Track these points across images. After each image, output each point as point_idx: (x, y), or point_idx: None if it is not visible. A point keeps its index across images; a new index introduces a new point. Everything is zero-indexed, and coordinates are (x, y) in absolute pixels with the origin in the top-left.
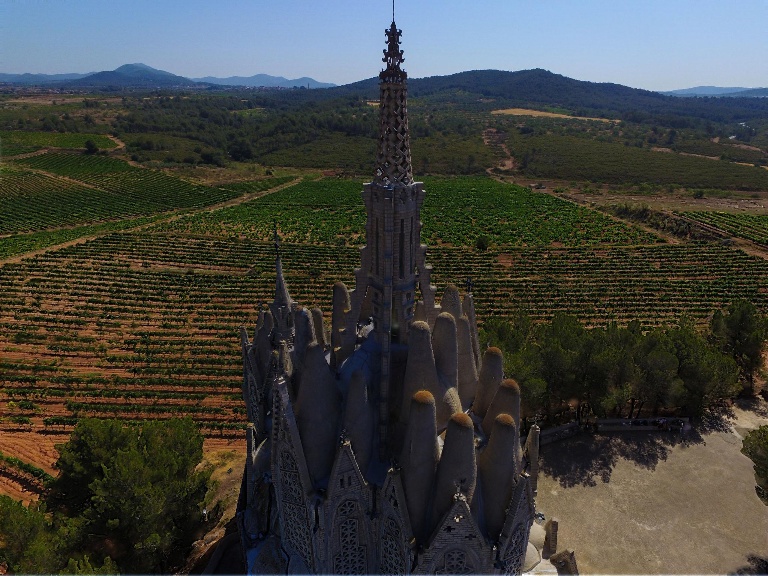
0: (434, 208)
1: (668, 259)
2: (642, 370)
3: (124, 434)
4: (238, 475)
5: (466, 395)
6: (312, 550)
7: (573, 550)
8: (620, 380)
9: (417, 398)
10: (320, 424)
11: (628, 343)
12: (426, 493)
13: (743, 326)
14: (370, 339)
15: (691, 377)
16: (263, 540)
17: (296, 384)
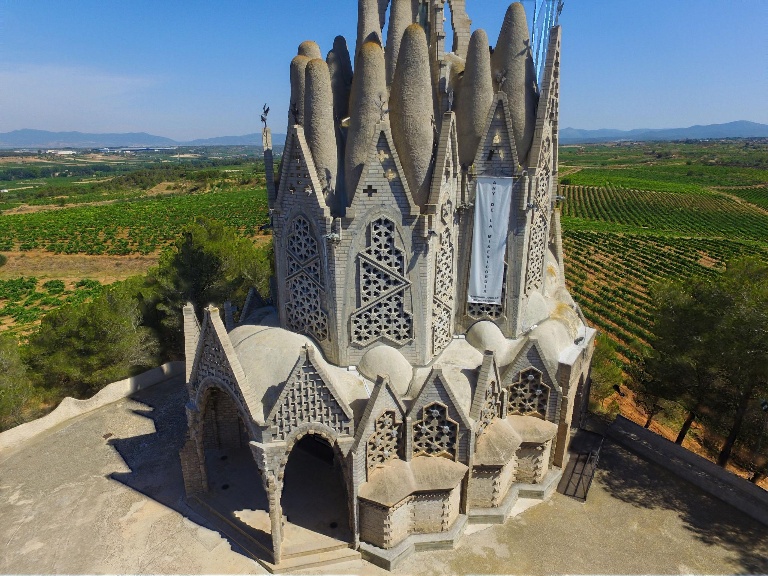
0: None
1: None
2: None
3: None
4: None
5: (464, 155)
6: None
7: (383, 376)
8: None
9: None
10: None
11: None
12: None
13: None
14: None
15: None
16: None
17: None
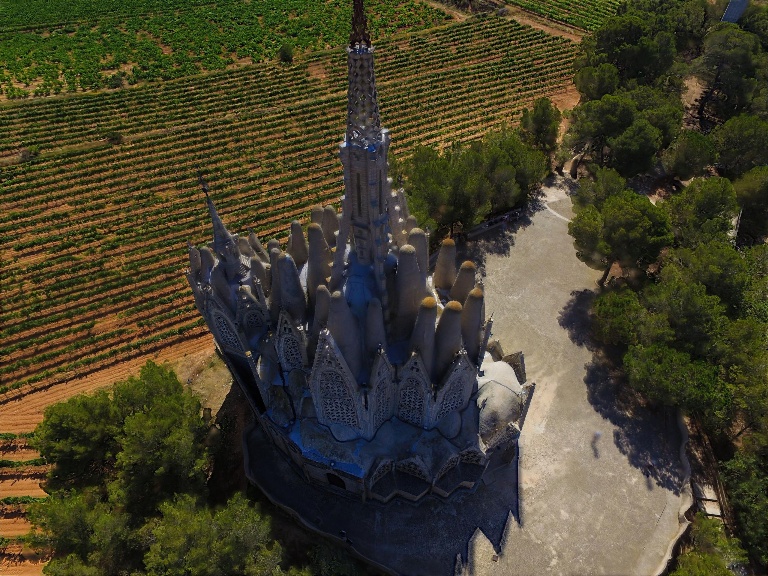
0: (205, 7)
1: (461, 41)
2: (492, 184)
3: (103, 404)
4: (187, 379)
5: None
6: (357, 418)
7: None
8: (479, 197)
9: (428, 305)
10: (353, 345)
11: (478, 164)
12: (432, 355)
13: (544, 120)
14: (354, 263)
15: (520, 176)
16: (294, 424)
17: (292, 313)
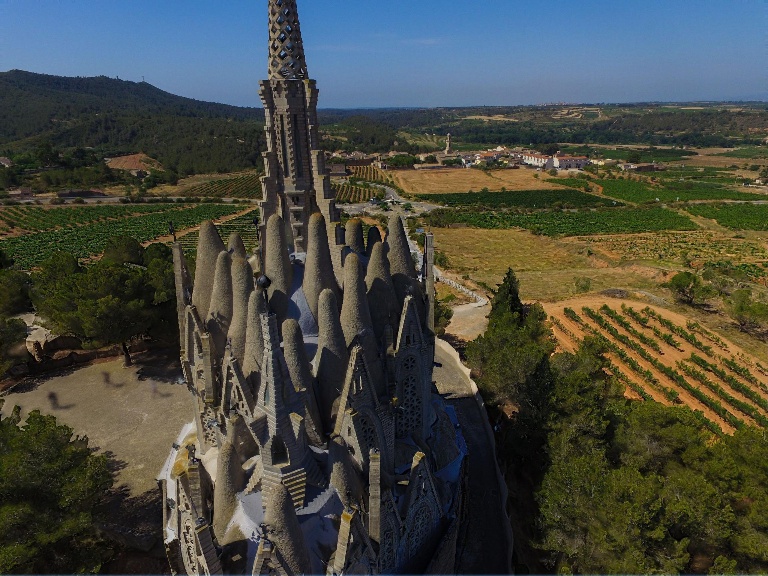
0: None
1: None
2: None
3: None
4: None
5: None
6: None
7: None
8: None
9: None
10: None
11: None
12: None
13: None
14: None
15: None
16: None
17: None
